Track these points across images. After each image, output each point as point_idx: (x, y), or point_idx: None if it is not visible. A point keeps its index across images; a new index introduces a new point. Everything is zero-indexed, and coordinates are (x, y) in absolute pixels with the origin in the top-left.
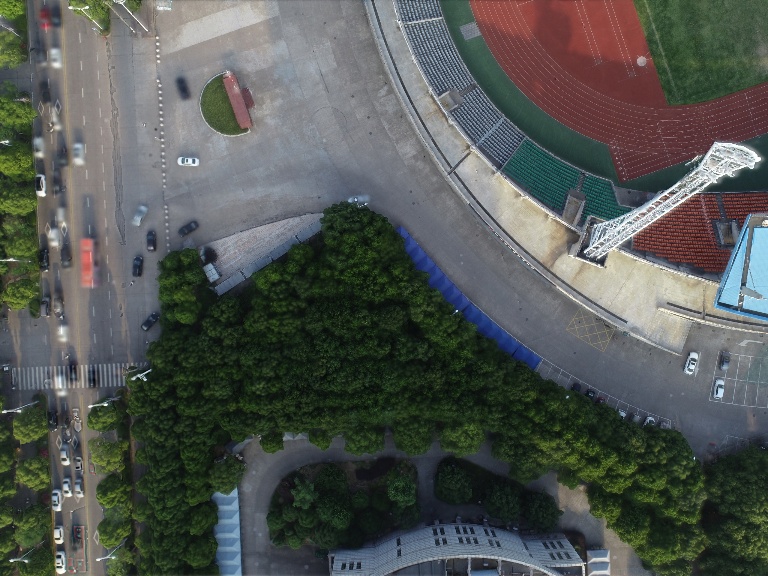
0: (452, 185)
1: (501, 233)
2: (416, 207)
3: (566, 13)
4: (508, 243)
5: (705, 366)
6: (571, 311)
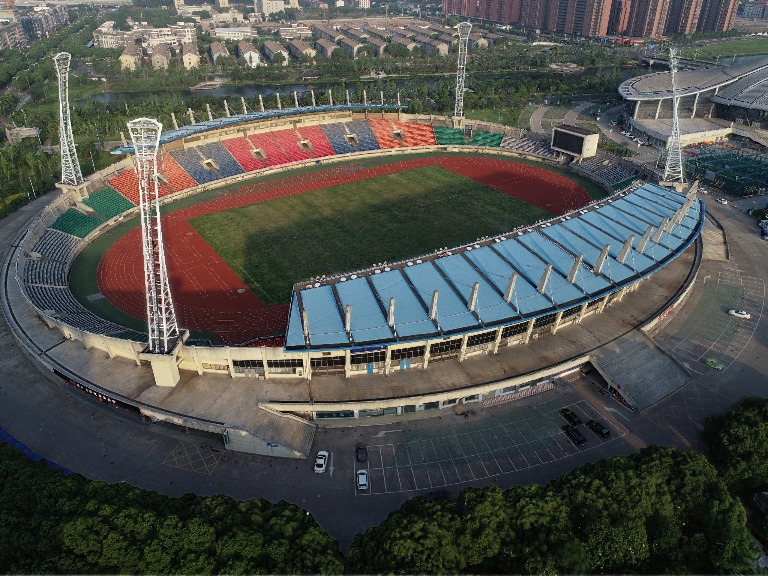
0: (49, 376)
1: (83, 383)
2: (2, 397)
3: (178, 280)
4: (87, 386)
5: (341, 463)
6: (170, 446)
